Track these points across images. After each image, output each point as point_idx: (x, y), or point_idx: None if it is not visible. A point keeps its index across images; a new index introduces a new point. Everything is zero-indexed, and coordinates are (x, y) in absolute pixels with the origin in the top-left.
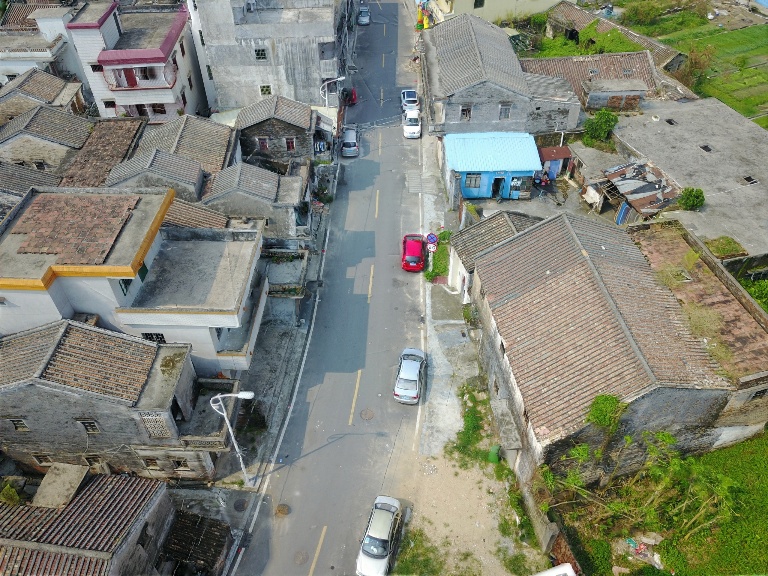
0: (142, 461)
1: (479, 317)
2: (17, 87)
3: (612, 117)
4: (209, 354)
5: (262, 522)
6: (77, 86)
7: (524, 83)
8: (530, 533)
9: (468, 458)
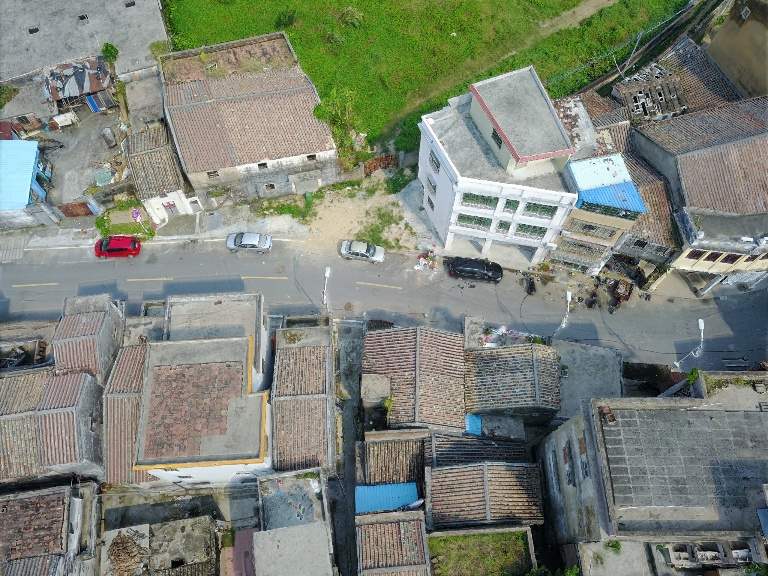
0: None
1: (222, 186)
2: None
3: None
4: (266, 336)
5: None
6: None
7: None
8: (356, 182)
9: (310, 212)
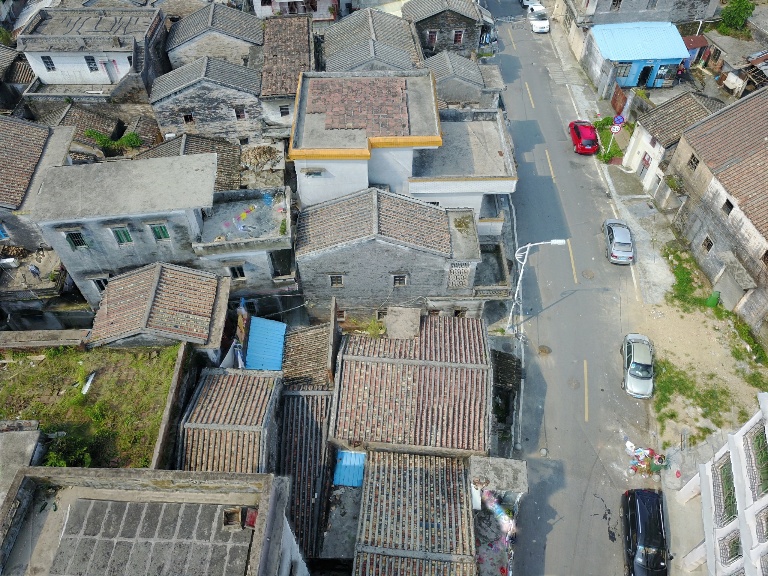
0: (428, 312)
1: (685, 186)
2: None
3: (751, 4)
4: None
5: (530, 360)
6: None
7: None
8: (763, 356)
9: (688, 304)
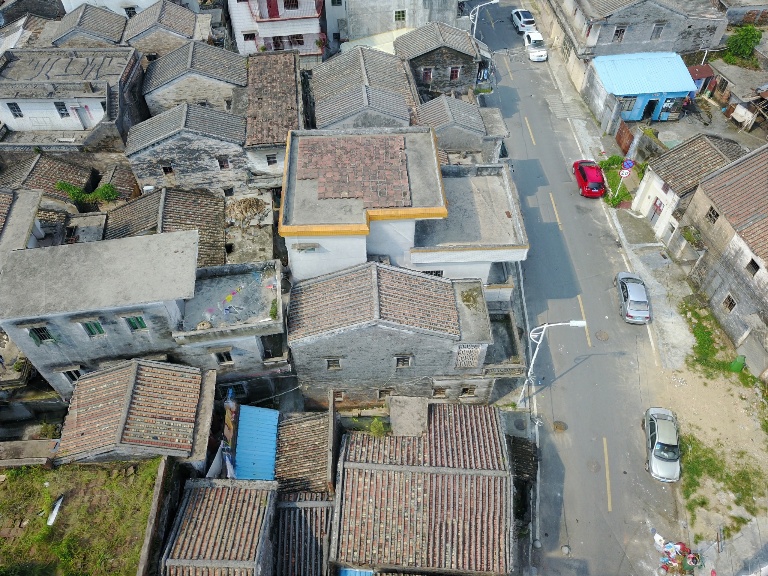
0: (433, 391)
1: (703, 239)
2: (158, 21)
3: (758, 33)
4: None
5: (545, 438)
6: (208, 18)
7: (674, 0)
8: None
9: (711, 369)
